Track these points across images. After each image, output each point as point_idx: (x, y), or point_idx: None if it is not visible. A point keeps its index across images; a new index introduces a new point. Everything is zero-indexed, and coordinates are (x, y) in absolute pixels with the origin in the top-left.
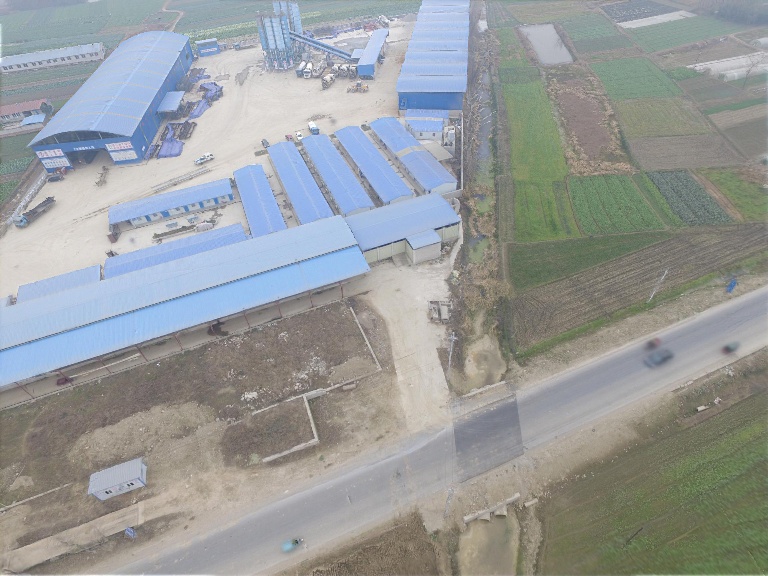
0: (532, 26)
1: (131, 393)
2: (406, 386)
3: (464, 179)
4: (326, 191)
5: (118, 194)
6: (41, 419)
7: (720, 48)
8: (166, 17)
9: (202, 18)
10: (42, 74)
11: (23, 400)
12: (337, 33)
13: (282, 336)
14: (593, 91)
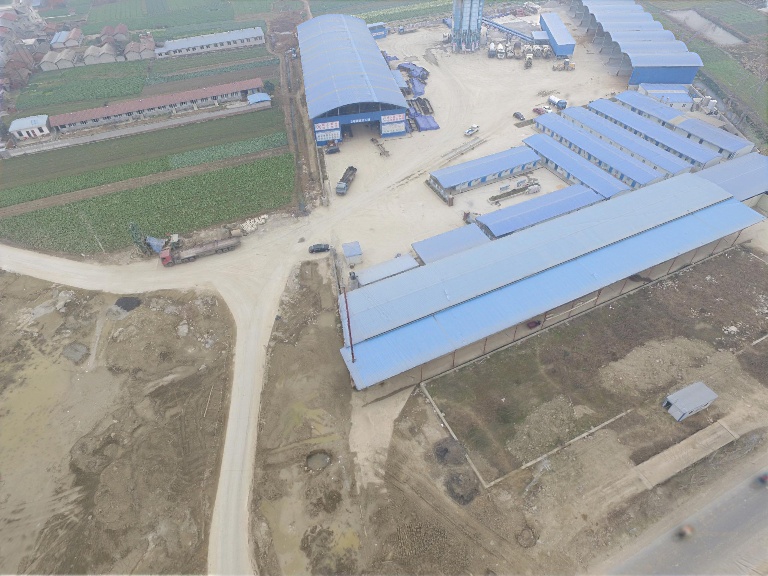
0: (674, 12)
1: (610, 332)
2: None
3: None
4: None
5: (411, 163)
6: (545, 357)
7: None
8: (292, 5)
9: (334, 5)
10: (215, 57)
11: (506, 343)
12: (490, 18)
13: (710, 279)
14: None
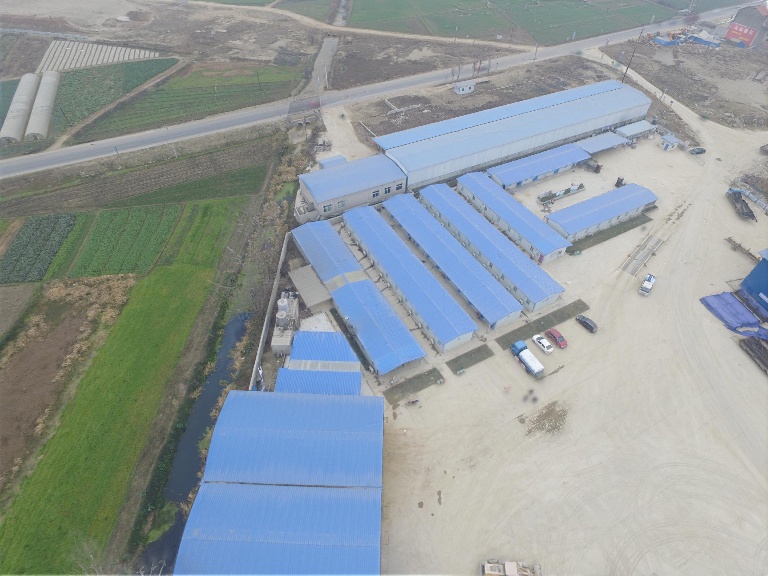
0: None
1: None
2: None
3: None
4: None
5: (692, 234)
6: None
7: None
8: None
9: None
10: None
11: None
12: None
13: None
14: None
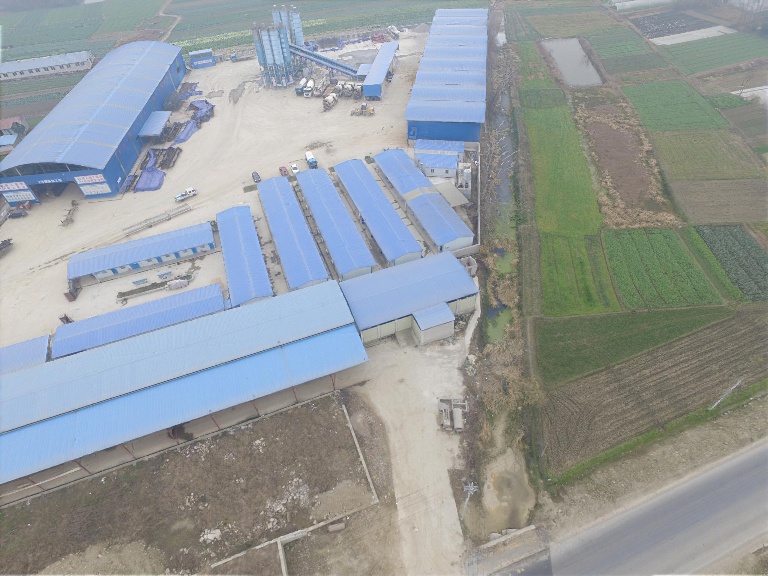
0: (555, 40)
1: (65, 523)
2: (409, 529)
3: (481, 229)
4: (321, 241)
5: (85, 237)
6: None
7: (767, 71)
8: (162, 22)
9: (200, 24)
10: (22, 85)
11: None
12: (343, 44)
13: (257, 444)
14: (627, 120)
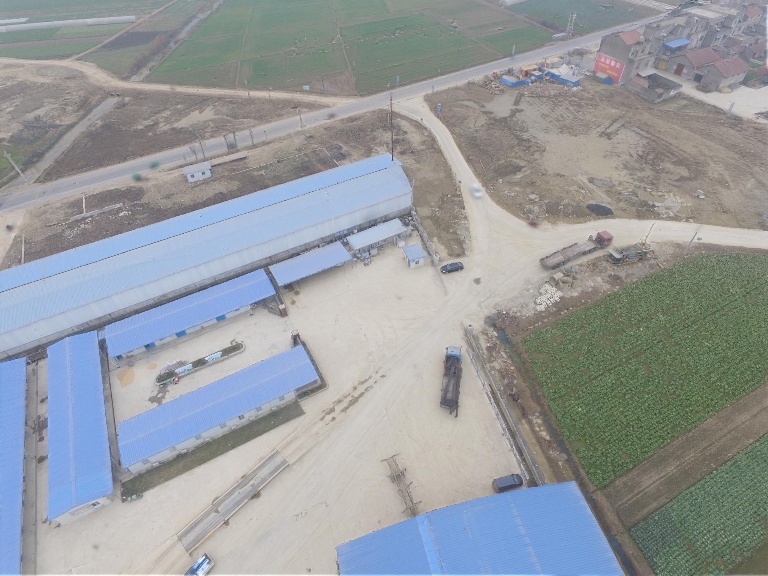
0: None
1: None
2: None
3: None
4: None
5: (346, 444)
6: None
7: None
8: None
9: None
10: None
11: None
12: None
13: None
14: None
